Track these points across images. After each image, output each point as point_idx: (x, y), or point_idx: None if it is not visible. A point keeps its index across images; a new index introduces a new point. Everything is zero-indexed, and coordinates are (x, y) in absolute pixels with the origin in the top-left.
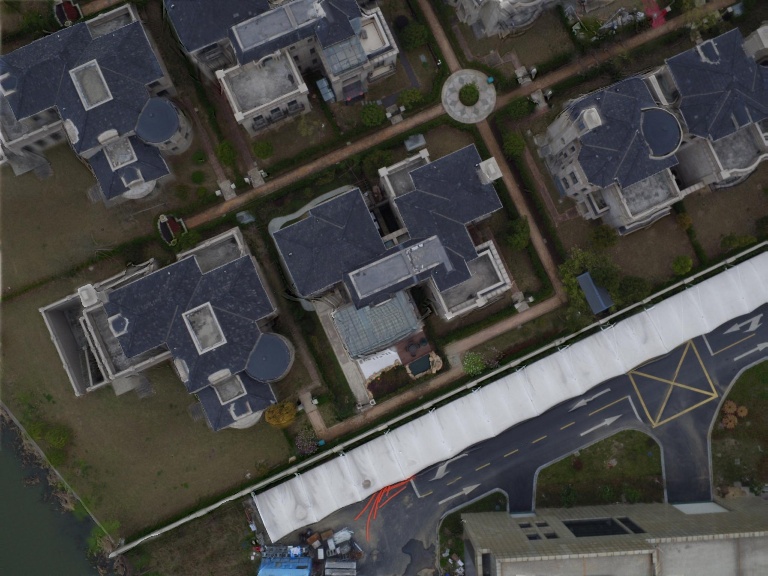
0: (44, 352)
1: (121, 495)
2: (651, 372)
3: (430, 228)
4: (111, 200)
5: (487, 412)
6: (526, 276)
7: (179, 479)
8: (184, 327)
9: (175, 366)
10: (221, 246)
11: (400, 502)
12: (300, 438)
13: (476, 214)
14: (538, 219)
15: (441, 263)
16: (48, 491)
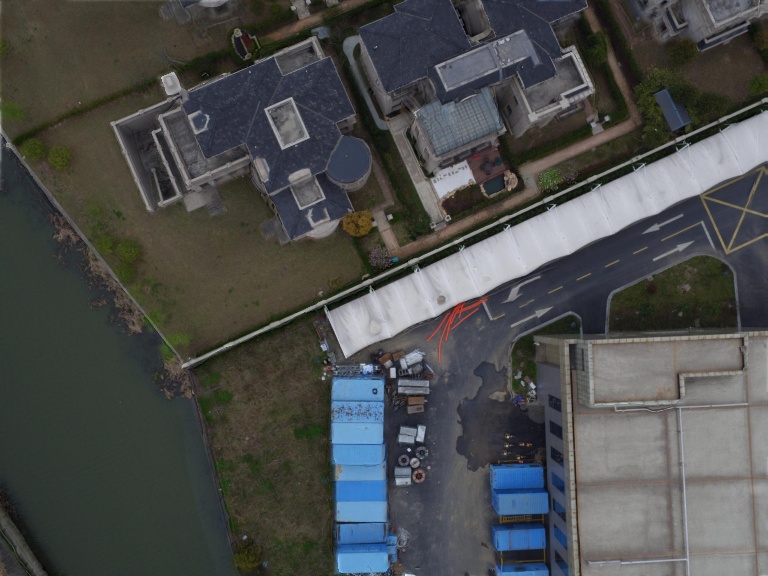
0: (114, 168)
1: (191, 313)
2: (724, 198)
3: (517, 22)
4: (187, 8)
5: (563, 229)
6: (602, 95)
7: (250, 297)
8: (266, 123)
9: (254, 168)
10: (298, 56)
11: (472, 324)
12: (373, 256)
13: (561, 13)
14: (614, 39)
15: (528, 57)
16: (115, 313)
